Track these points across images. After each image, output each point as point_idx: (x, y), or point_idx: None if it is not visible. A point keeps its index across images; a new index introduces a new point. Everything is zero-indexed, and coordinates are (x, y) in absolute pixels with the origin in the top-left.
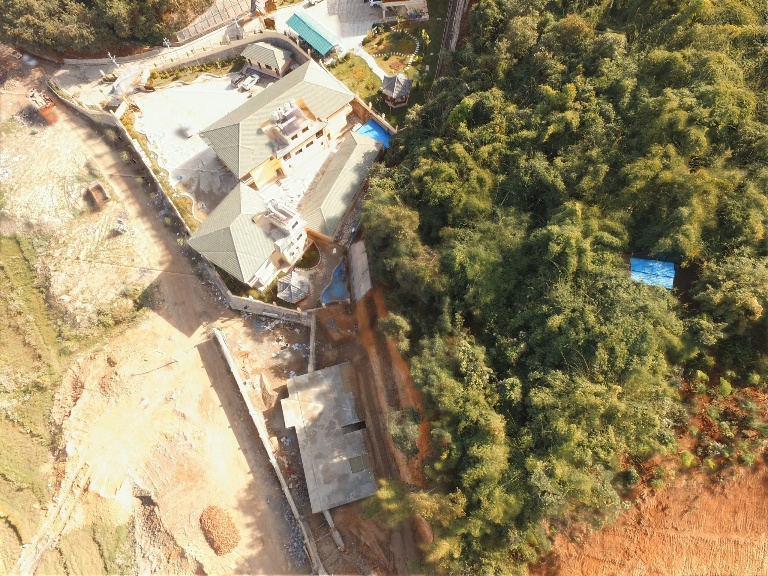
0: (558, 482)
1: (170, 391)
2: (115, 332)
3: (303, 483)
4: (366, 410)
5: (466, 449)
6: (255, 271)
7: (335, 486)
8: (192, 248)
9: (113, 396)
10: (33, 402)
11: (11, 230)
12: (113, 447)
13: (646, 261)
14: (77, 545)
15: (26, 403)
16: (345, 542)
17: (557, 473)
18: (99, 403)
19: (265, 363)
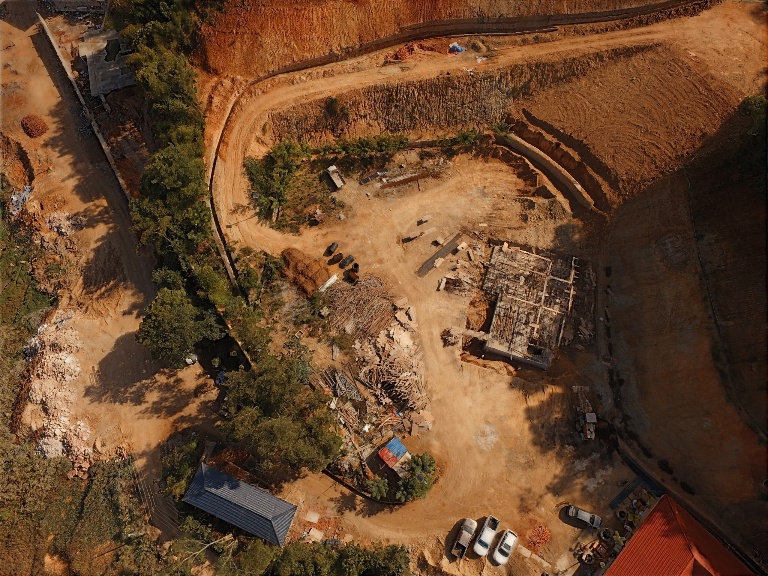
0: None
1: (8, 62)
2: None
3: None
4: None
5: None
6: None
7: (109, 81)
8: None
9: None
10: None
11: None
12: None
13: None
14: None
15: None
16: (112, 108)
17: None
18: None
19: (76, 36)
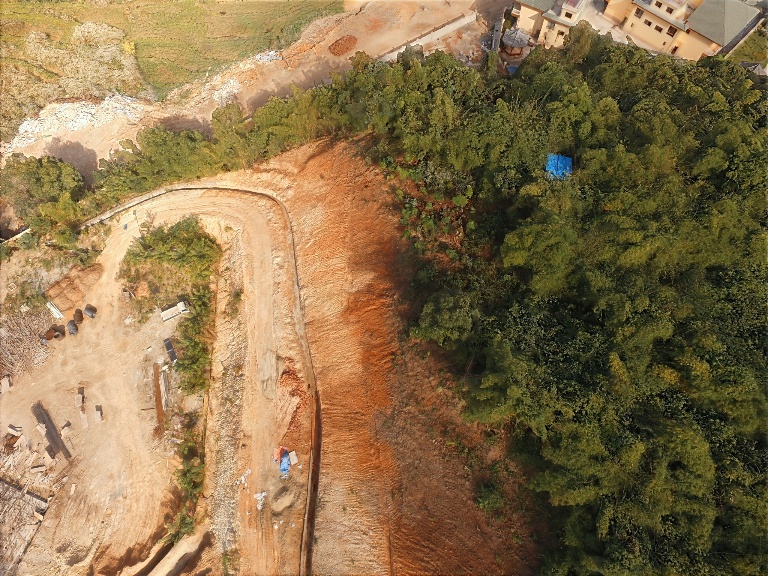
0: (381, 95)
1: (429, 7)
2: None
3: None
4: None
5: None
6: (523, 2)
7: None
8: None
9: None
10: None
11: None
12: None
13: (570, 165)
14: None
15: None
16: None
17: (386, 87)
18: None
19: (455, 49)
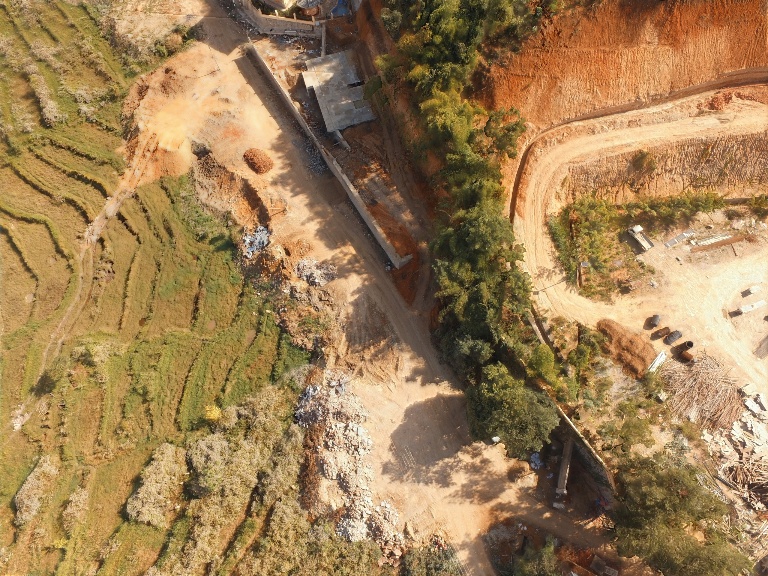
0: None
1: (215, 88)
2: (169, 59)
3: (319, 126)
4: (365, 74)
5: (432, 7)
6: None
7: (343, 116)
8: (226, 1)
9: (171, 93)
10: (107, 108)
11: (78, 0)
12: (174, 123)
13: None
14: (149, 192)
15: (101, 109)
16: (351, 146)
17: None
18: (161, 98)
19: (288, 62)
